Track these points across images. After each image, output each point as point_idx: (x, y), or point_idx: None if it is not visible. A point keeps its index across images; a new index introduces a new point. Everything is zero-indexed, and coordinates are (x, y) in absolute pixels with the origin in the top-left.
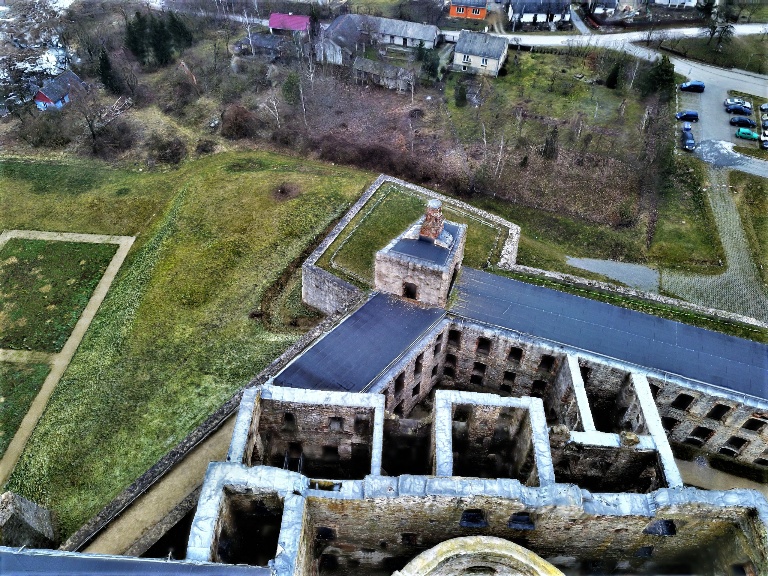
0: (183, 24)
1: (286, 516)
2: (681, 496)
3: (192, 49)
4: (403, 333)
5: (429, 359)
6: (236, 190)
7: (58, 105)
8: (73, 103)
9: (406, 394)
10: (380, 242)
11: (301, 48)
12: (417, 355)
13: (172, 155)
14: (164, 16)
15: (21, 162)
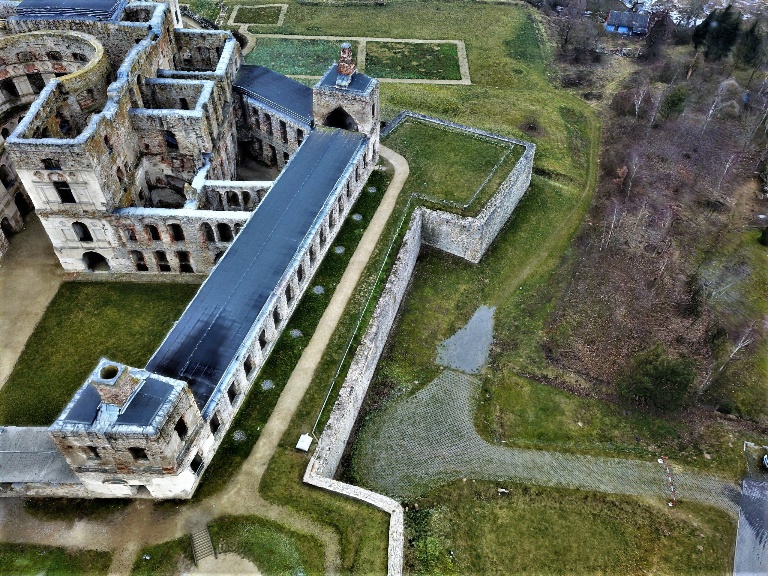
0: (759, 41)
1: (138, 22)
2: (95, 117)
3: (751, 69)
4: (292, 104)
5: (294, 142)
6: (529, 109)
7: (610, 28)
8: (568, 7)
9: (277, 146)
10: (437, 142)
11: (765, 103)
12: (280, 117)
13: (572, 83)
14: (748, 23)
15: (536, 32)
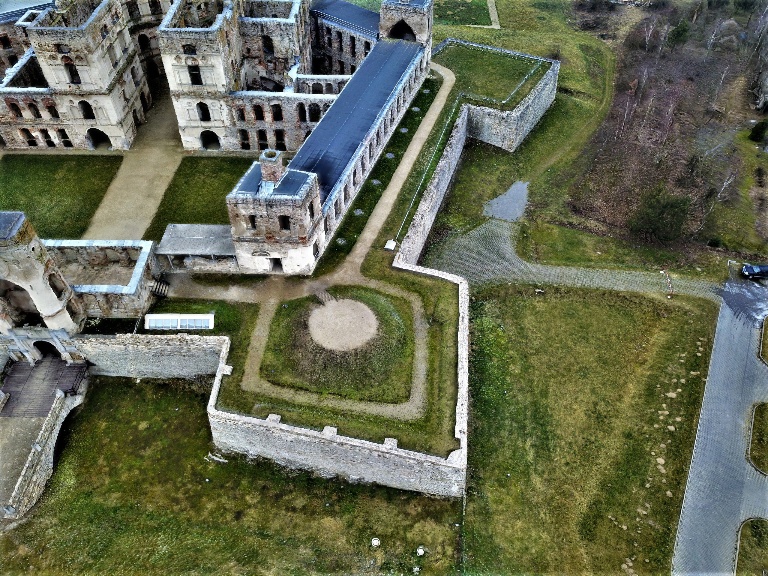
0: None
1: None
2: None
3: None
4: (360, 22)
5: (361, 54)
6: (552, 44)
7: None
8: None
9: (346, 61)
10: (477, 60)
11: (760, 34)
12: (350, 33)
13: (590, 26)
14: None
15: None
